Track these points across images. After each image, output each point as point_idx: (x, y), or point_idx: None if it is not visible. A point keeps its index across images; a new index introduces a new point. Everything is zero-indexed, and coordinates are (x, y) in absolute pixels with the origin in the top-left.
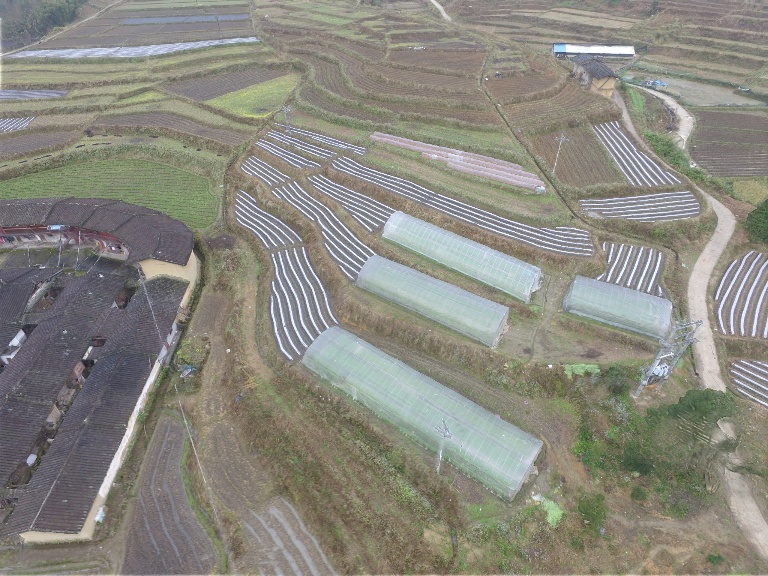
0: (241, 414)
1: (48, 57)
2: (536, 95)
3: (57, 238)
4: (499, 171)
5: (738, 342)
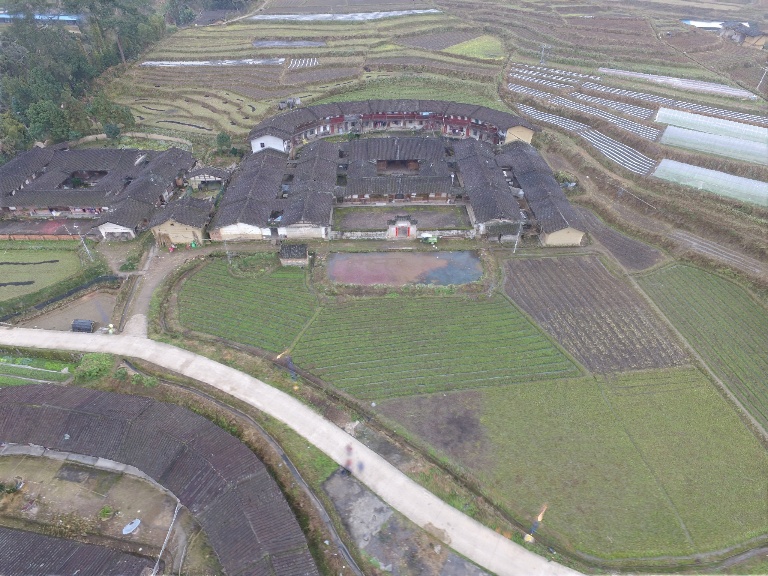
0: (627, 199)
1: (285, 19)
2: (708, 47)
3: (413, 125)
4: (715, 88)
5: None
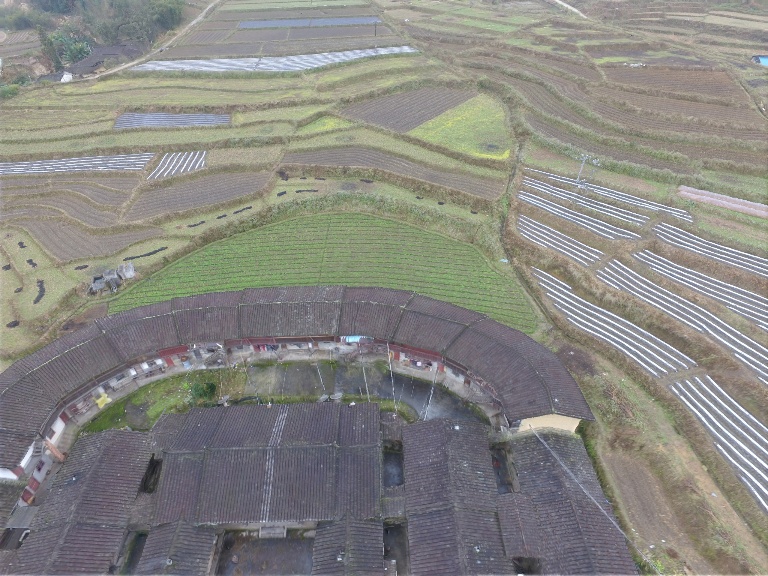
0: None
1: (185, 70)
2: None
3: (334, 345)
4: None
5: None
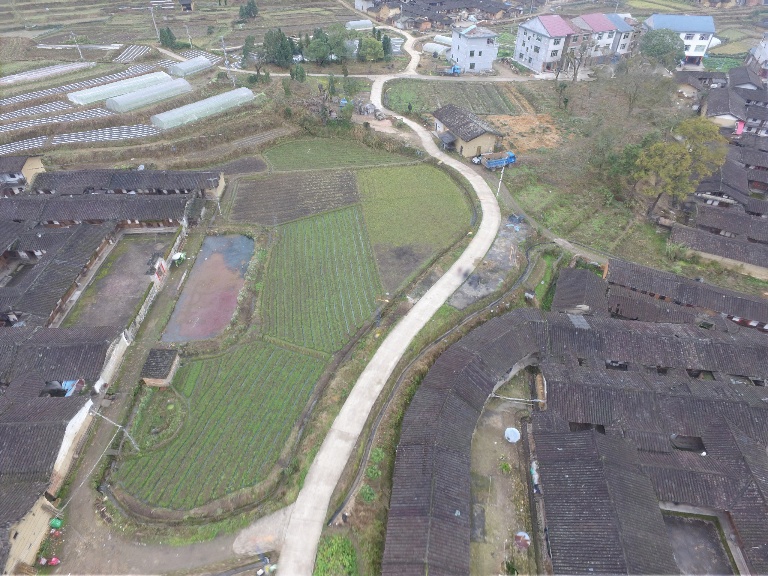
0: (183, 149)
1: None
2: None
3: None
4: (59, 69)
5: (219, 64)
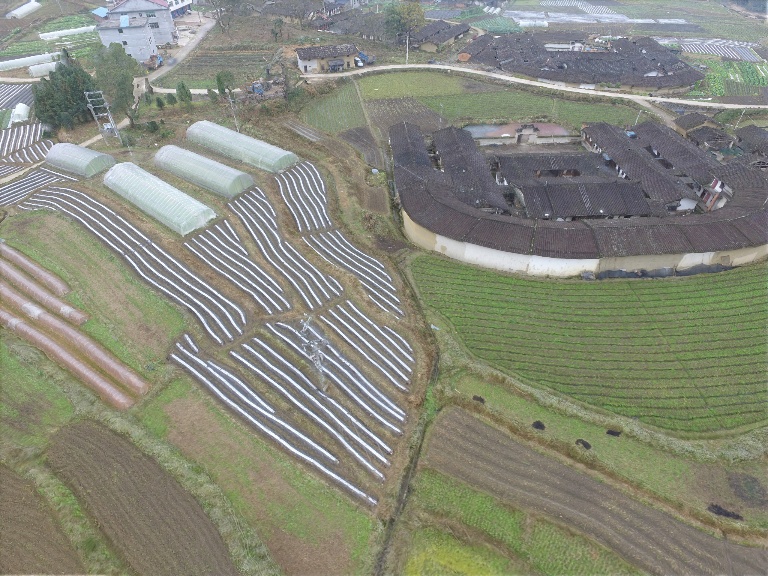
0: None
1: None
2: None
3: None
4: (9, 270)
5: None
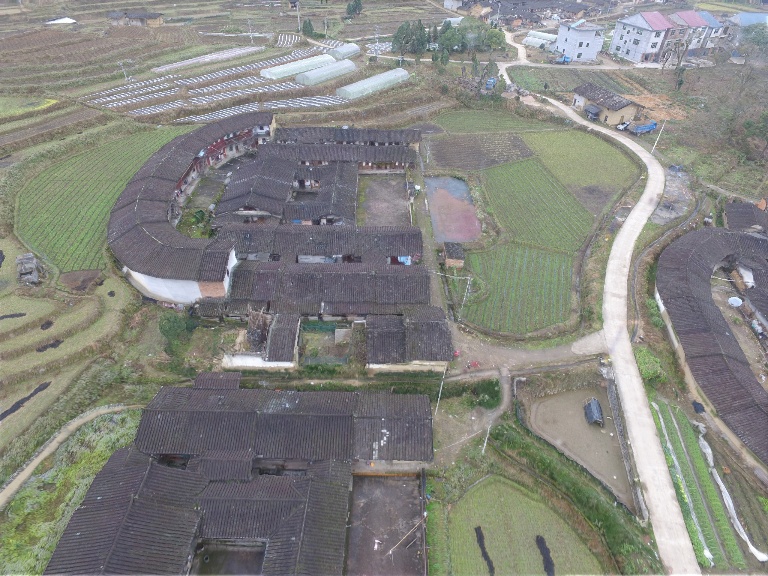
0: (371, 115)
1: None
2: None
3: None
4: (239, 51)
5: None
